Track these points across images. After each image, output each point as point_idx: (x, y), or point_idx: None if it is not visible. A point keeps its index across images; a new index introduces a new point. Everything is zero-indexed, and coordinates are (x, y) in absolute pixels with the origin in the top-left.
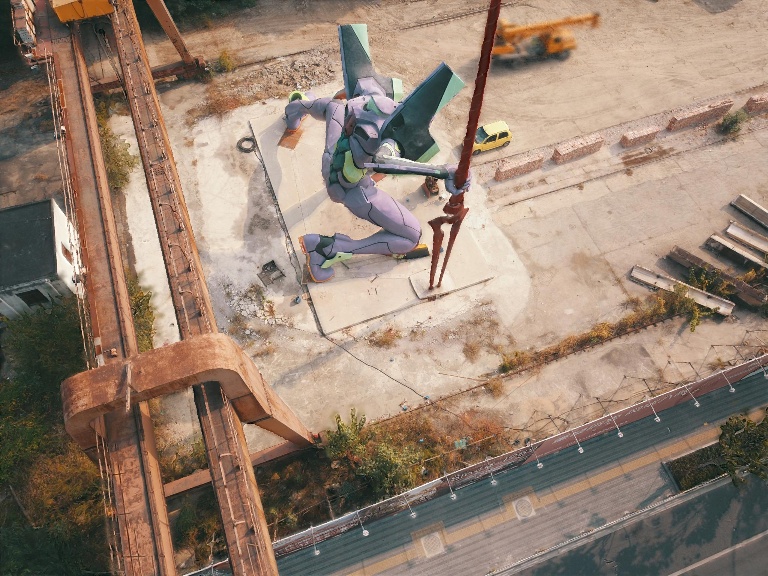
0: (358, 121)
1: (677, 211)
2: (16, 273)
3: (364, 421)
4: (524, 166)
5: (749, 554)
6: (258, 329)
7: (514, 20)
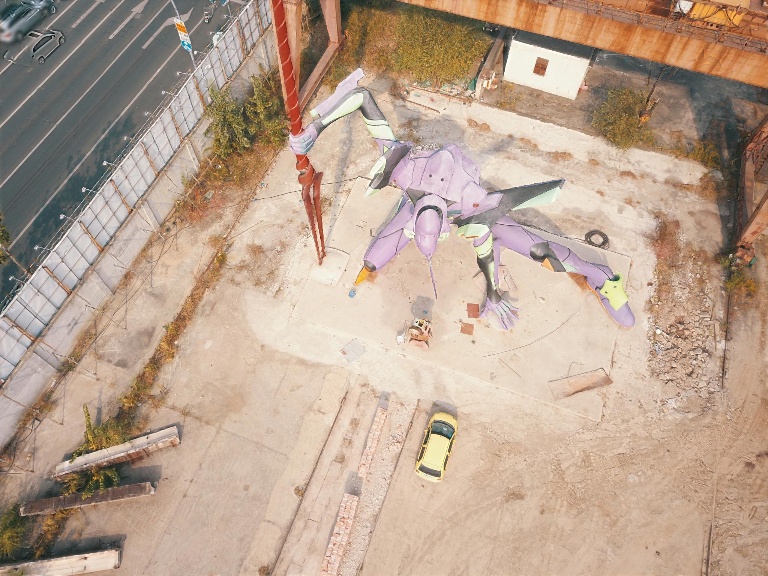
0: None
1: (176, 567)
2: None
3: None
4: None
5: None
6: None
7: None
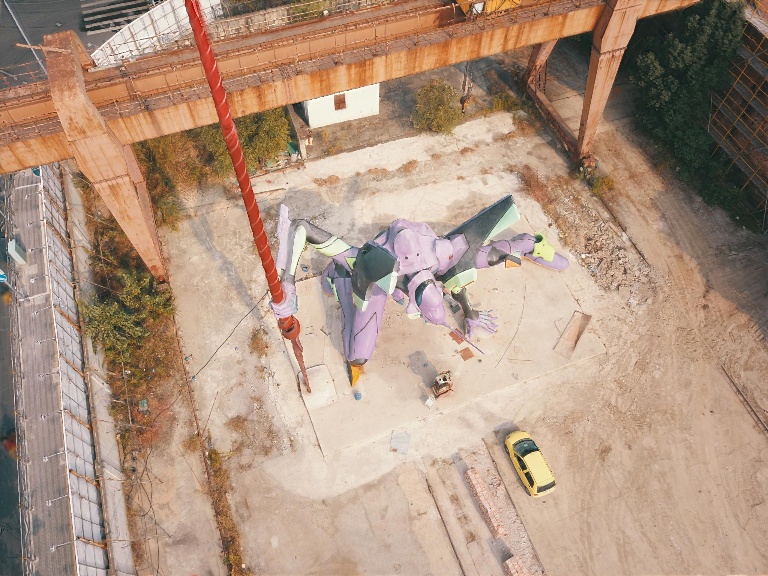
0: None
1: None
2: None
3: None
4: None
5: None
6: None
7: None
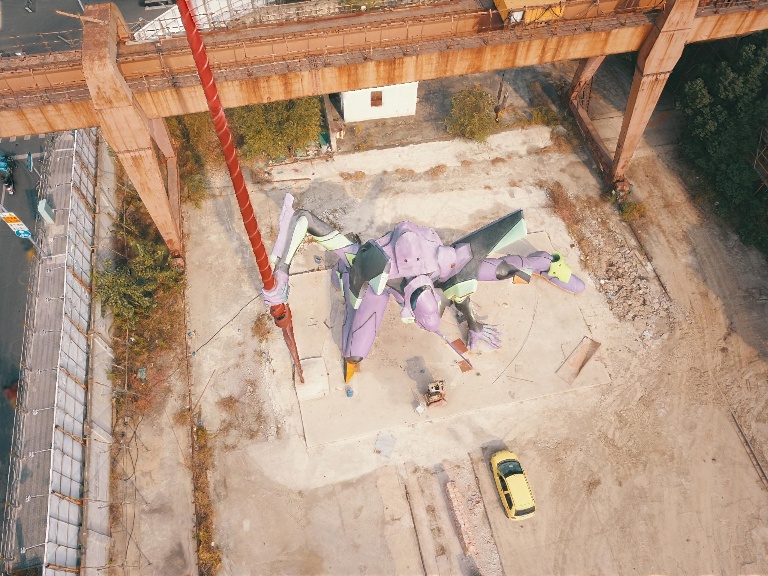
0: None
1: None
2: None
3: None
4: None
5: None
6: None
7: None
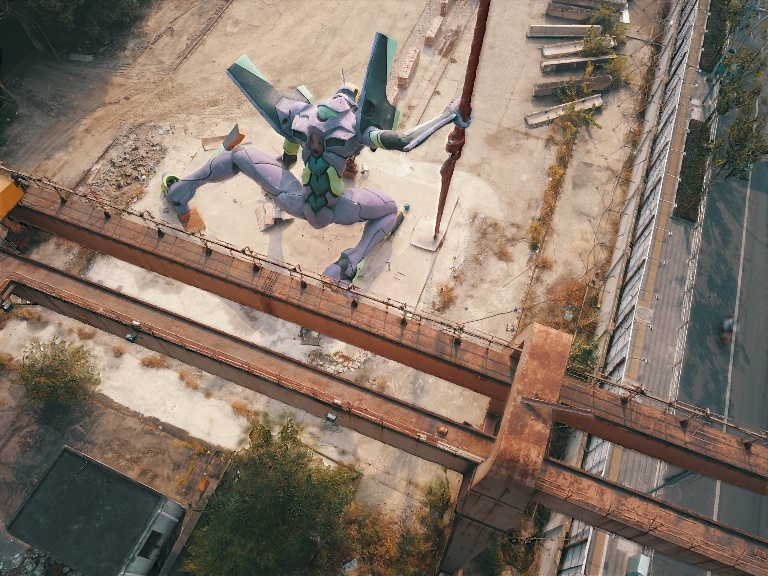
0: (325, 134)
1: (506, 64)
2: (120, 536)
3: None
4: None
5: (753, 225)
6: (353, 380)
7: (253, 6)
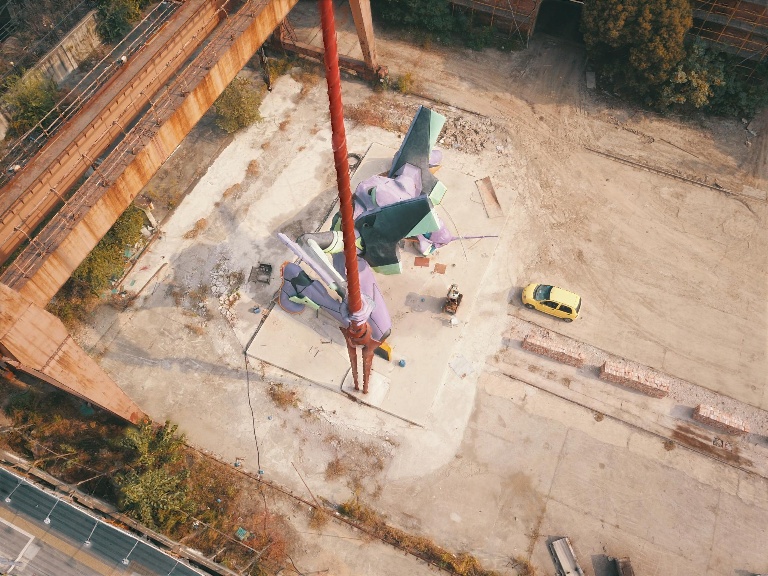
0: (357, 197)
1: (680, 527)
2: None
3: (165, 441)
4: (557, 353)
5: None
6: (210, 308)
7: (713, 210)
